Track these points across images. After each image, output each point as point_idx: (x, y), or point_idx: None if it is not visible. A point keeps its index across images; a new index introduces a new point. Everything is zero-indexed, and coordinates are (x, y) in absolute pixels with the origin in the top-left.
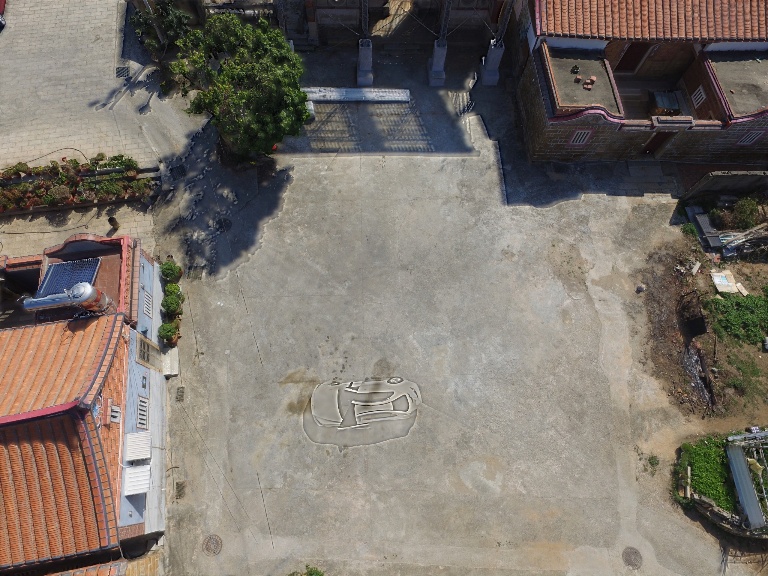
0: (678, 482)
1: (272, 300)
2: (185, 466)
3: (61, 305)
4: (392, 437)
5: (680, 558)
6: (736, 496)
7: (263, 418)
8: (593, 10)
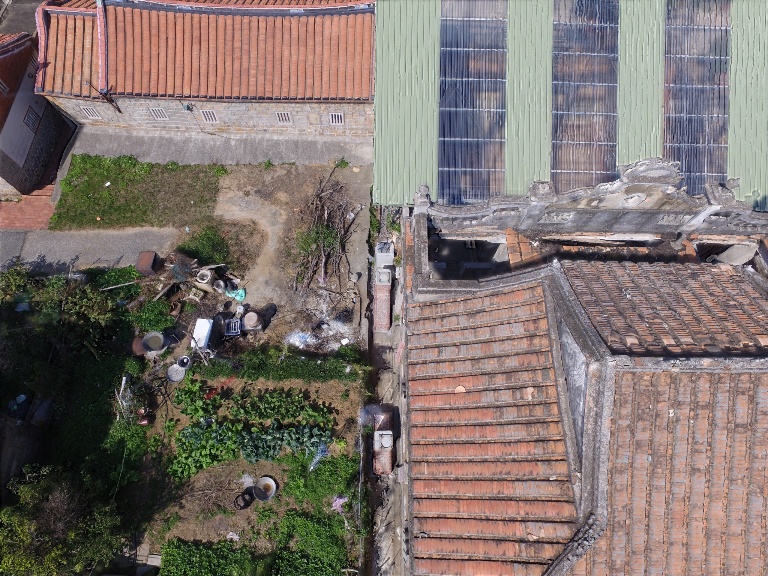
0: None
1: None
2: None
3: None
4: None
5: None
6: None
7: None
8: (325, 3)
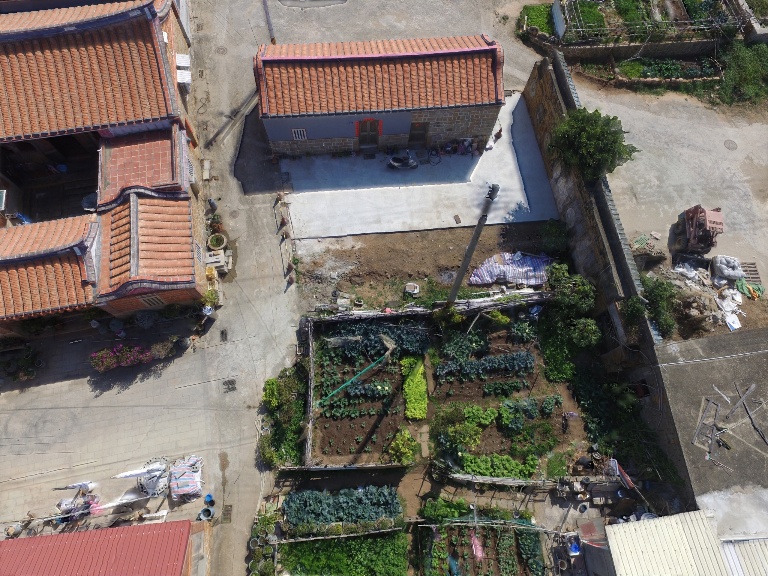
0: (519, 26)
1: None
2: (202, 17)
3: None
4: (336, 4)
5: (517, 62)
6: (554, 28)
7: None
8: None
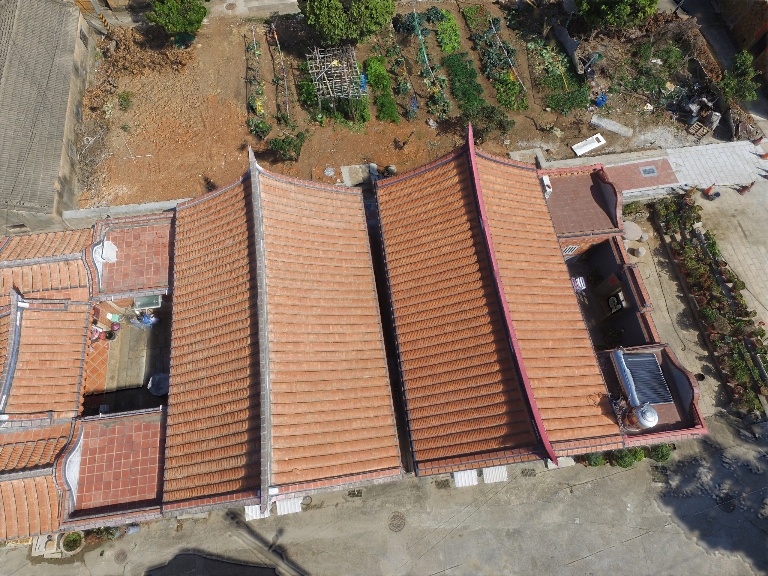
0: None
1: (645, 573)
2: None
3: (622, 383)
4: None
5: None
6: None
7: (512, 568)
8: None
